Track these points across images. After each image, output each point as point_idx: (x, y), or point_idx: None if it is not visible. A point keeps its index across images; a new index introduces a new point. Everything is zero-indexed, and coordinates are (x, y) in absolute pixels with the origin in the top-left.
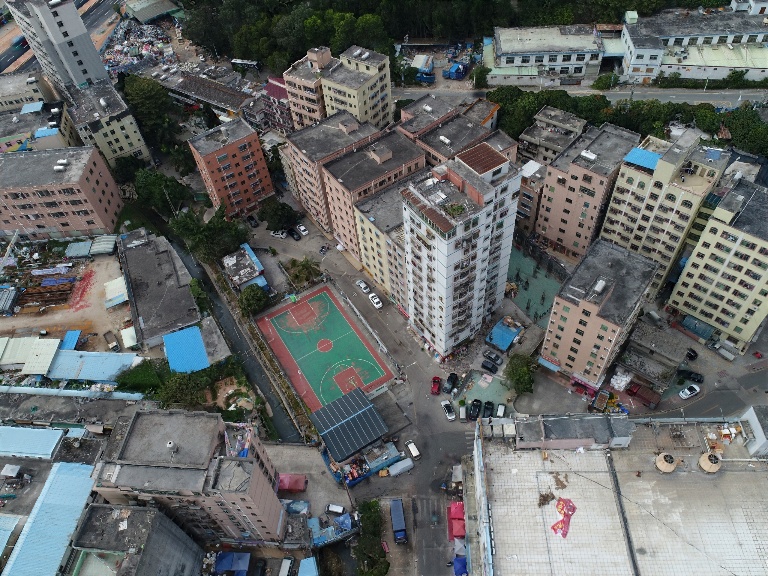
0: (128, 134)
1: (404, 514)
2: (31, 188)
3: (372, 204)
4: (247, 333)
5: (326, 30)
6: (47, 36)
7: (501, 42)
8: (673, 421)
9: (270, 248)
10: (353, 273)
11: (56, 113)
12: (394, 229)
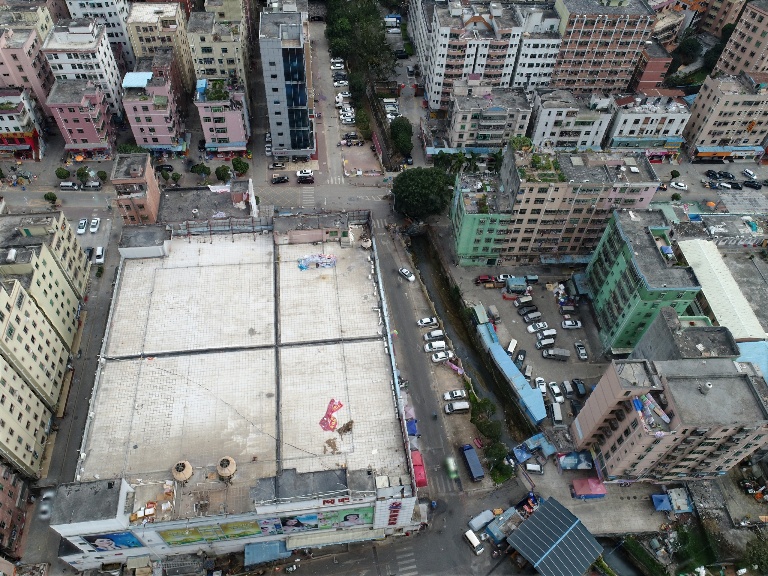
0: None
1: (467, 474)
2: None
3: None
4: None
5: None
6: None
7: None
8: (202, 518)
9: None
10: None
11: None
12: None
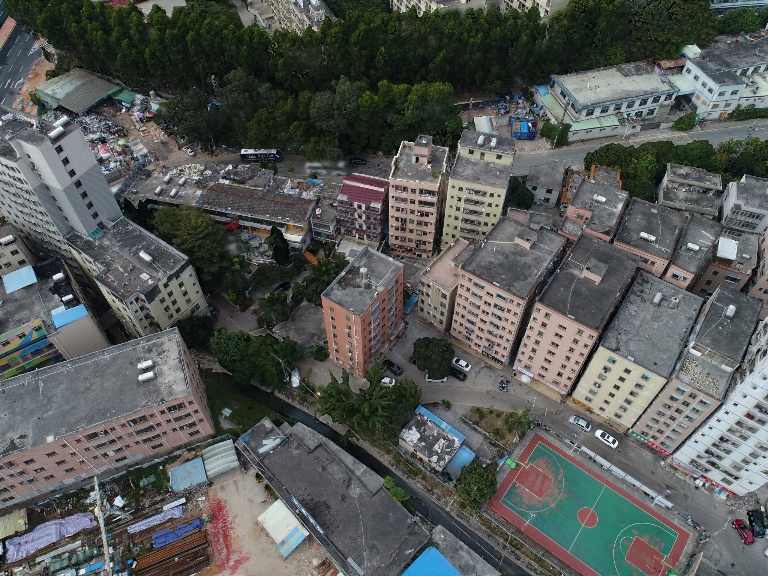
0: (186, 289)
1: None
2: (121, 420)
3: (615, 337)
4: (481, 529)
5: (383, 106)
6: (40, 179)
7: (572, 93)
8: None
9: (443, 401)
10: (556, 408)
11: (61, 280)
12: (680, 370)
